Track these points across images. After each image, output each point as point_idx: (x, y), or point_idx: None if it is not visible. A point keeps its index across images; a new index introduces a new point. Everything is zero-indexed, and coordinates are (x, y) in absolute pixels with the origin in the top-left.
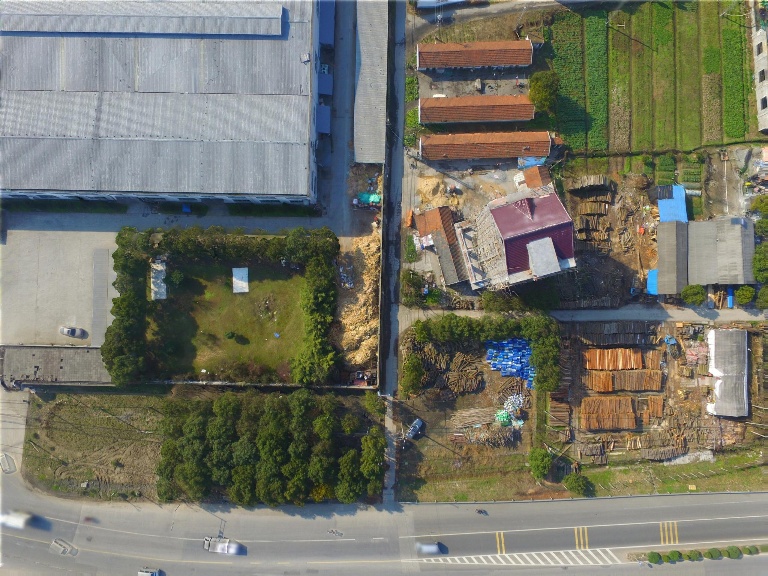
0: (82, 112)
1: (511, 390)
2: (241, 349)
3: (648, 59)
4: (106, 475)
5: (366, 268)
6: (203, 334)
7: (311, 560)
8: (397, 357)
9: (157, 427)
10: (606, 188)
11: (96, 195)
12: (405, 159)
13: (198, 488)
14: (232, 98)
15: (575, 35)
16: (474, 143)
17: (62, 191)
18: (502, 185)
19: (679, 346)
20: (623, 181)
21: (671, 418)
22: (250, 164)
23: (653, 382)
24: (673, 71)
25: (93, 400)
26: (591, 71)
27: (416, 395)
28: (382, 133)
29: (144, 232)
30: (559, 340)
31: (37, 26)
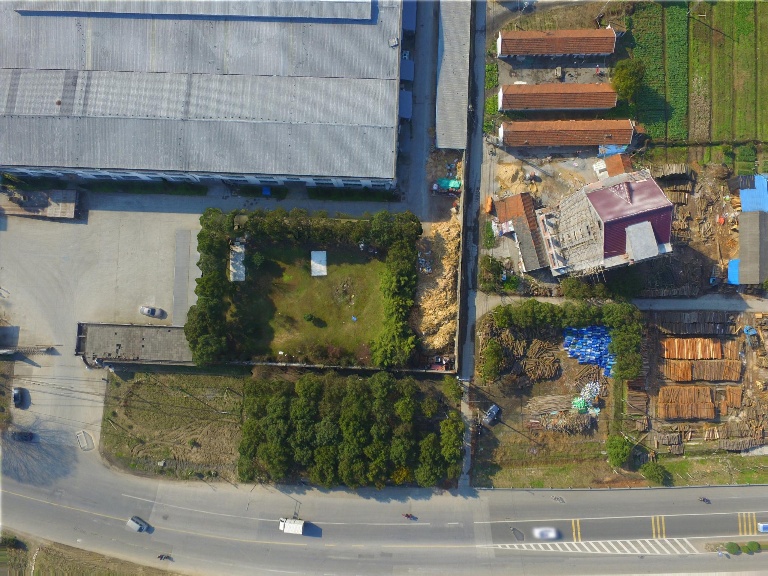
0: (172, 93)
1: (588, 378)
2: (318, 332)
3: (729, 49)
4: (183, 454)
5: (446, 253)
6: (281, 316)
7: (386, 543)
8: (474, 343)
9: (234, 408)
10: (687, 177)
11: (182, 176)
12: (484, 146)
13: (281, 467)
14: (320, 81)
15: (656, 24)
16: (556, 130)
17: (150, 171)
18: (581, 173)
19: (758, 337)
20: (703, 171)
21: (750, 409)
22: (337, 147)
23: (732, 372)
24: (754, 62)
25: (171, 380)
26: (672, 60)
27: (492, 381)
28: (464, 119)
29: (230, 213)
30: (641, 328)
31: (130, 8)
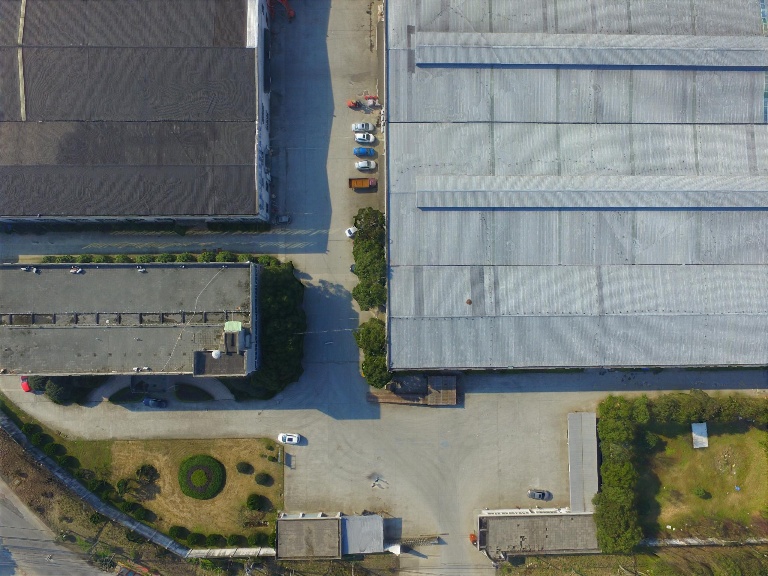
0: (583, 287)
1: None
2: (704, 504)
3: None
4: None
5: None
6: (667, 491)
7: None
8: None
9: None
10: None
11: None
12: None
13: None
14: (728, 268)
15: None
16: None
17: (564, 367)
18: None
19: None
20: None
21: None
22: (752, 335)
23: None
24: None
25: (563, 562)
26: None
27: None
28: None
29: (643, 404)
30: None
31: (540, 202)
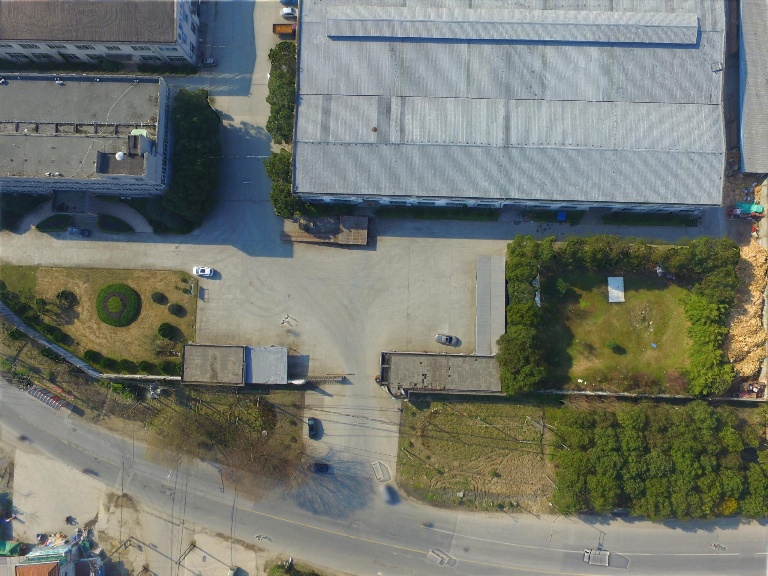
0: (490, 119)
1: None
2: (618, 359)
3: None
4: (483, 485)
5: (755, 279)
6: (579, 343)
7: (694, 574)
8: None
9: (534, 437)
10: None
11: (492, 203)
12: None
13: (613, 500)
14: (641, 107)
15: None
16: None
17: (468, 198)
18: None
19: None
20: None
21: None
22: (663, 173)
23: None
24: None
25: (469, 409)
26: None
27: None
28: None
29: (549, 240)
30: None
31: (448, 33)
